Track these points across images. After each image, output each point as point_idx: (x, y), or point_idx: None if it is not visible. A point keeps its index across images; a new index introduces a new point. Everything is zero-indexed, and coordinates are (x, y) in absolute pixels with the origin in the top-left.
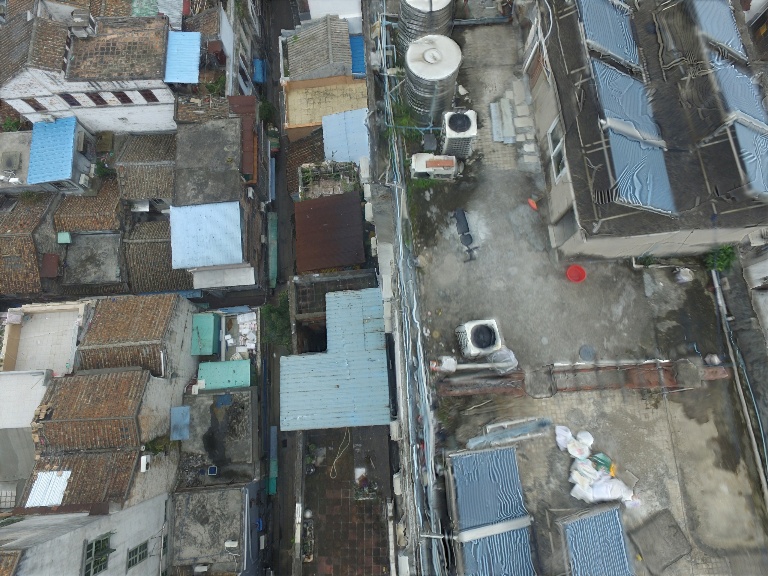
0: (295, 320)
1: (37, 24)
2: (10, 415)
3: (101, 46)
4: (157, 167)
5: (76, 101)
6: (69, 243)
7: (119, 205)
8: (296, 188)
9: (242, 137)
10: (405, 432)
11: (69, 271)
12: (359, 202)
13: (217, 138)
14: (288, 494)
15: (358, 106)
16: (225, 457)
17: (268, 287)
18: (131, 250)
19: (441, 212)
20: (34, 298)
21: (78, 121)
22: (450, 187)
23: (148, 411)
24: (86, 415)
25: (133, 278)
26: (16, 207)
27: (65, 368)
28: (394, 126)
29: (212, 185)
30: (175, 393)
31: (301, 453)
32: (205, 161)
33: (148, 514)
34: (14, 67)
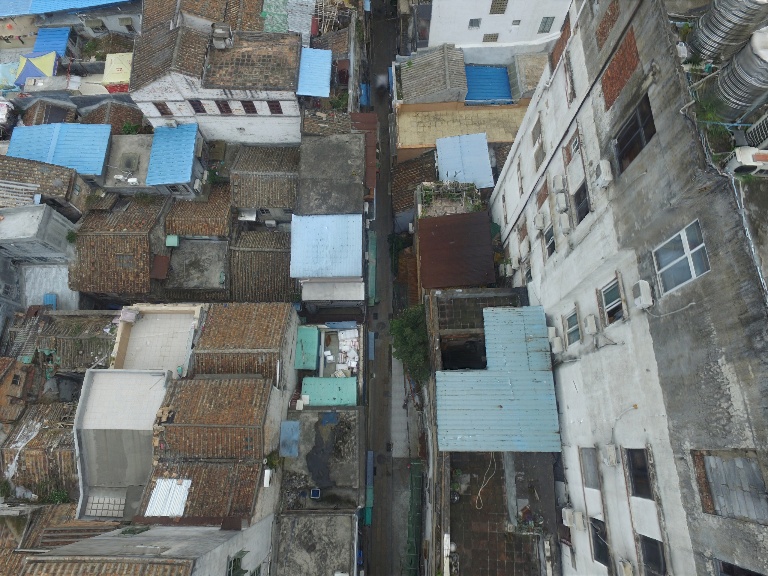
0: (439, 335)
1: (182, 32)
2: (126, 415)
3: (236, 57)
4: (271, 177)
5: (202, 108)
6: (174, 247)
7: (229, 212)
8: (403, 208)
9: (366, 152)
10: (760, 446)
11: (172, 275)
12: (488, 222)
13: (341, 151)
14: (377, 527)
15: (468, 132)
16: (329, 480)
17: (367, 305)
18: (236, 258)
19: (760, 210)
20: (133, 300)
21: (198, 128)
22: (766, 185)
23: (269, 422)
24: (210, 421)
25: (235, 286)
26: (130, 207)
27: (174, 372)
28: (696, 121)
29: (336, 196)
30: (284, 406)
31: (449, 478)
32: (329, 173)
33: (262, 535)
34: (155, 71)
